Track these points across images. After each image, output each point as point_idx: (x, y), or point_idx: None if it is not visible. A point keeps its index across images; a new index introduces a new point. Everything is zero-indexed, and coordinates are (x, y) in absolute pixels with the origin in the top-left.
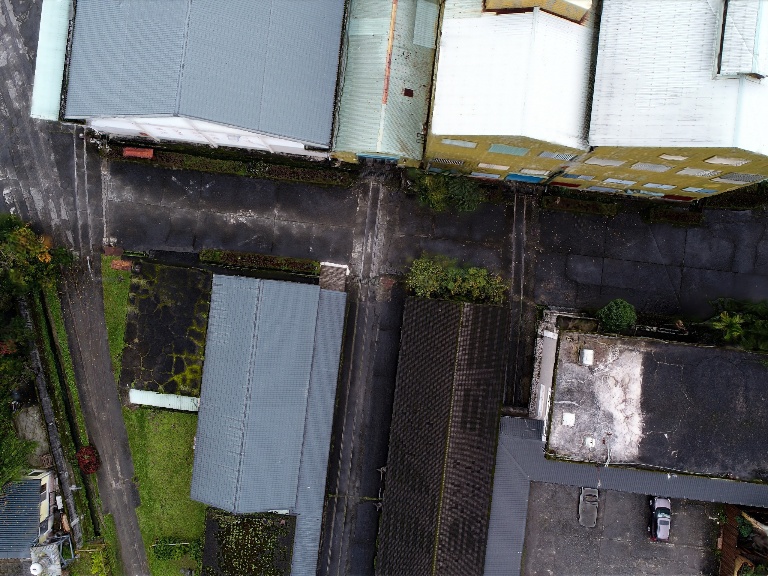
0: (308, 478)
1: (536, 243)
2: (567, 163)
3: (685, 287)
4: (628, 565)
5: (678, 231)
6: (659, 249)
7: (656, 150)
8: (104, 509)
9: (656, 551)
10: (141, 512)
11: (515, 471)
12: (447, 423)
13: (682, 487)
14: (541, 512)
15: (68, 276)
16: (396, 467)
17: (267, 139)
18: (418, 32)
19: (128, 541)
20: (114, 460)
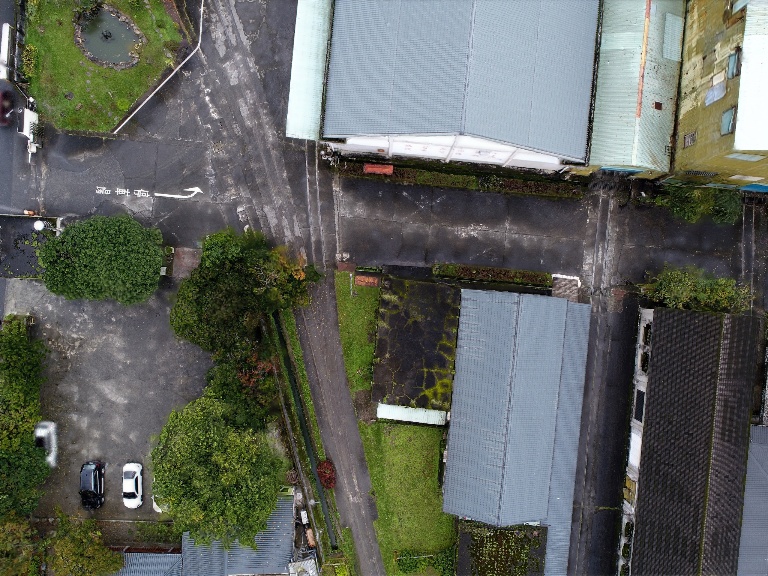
0: (557, 489)
1: (765, 252)
2: None
3: None
4: None
5: None
6: None
7: None
8: (342, 523)
9: None
10: (379, 525)
11: (762, 479)
12: (710, 433)
13: None
14: None
15: None
16: (651, 477)
17: (520, 154)
18: (667, 46)
19: (366, 554)
20: (351, 474)
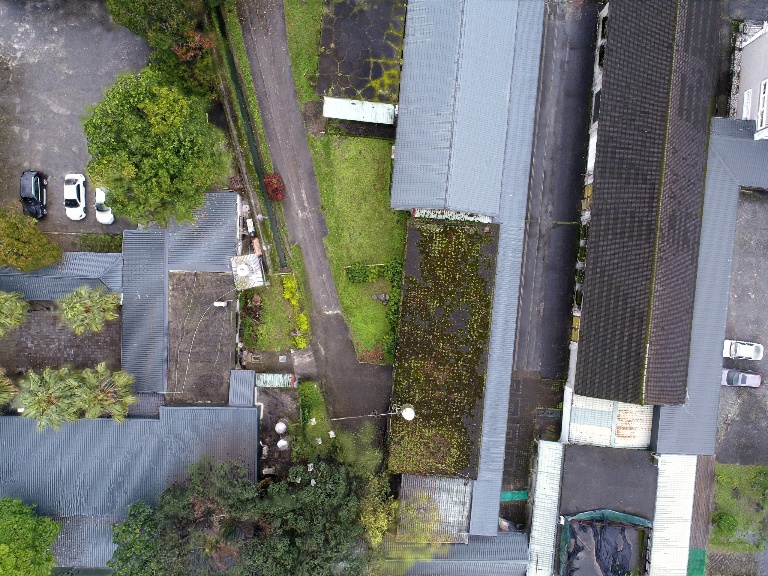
0: (510, 186)
1: None
2: None
3: None
4: None
5: None
6: None
7: None
8: (291, 239)
9: None
10: (329, 241)
11: (724, 174)
12: (666, 106)
13: None
14: (741, 234)
15: (249, 1)
16: (606, 165)
17: None
18: None
19: (316, 271)
20: (300, 189)
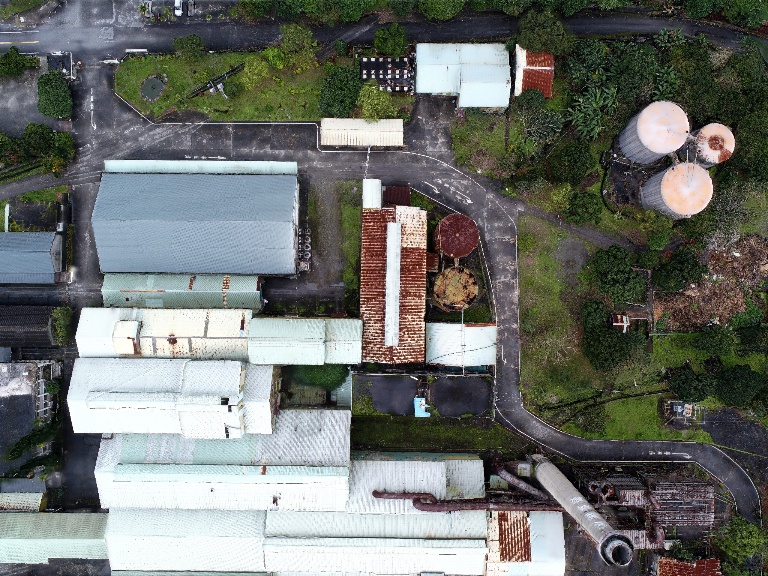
0: None
1: None
2: None
3: None
4: None
5: None
6: None
7: None
8: None
9: None
10: None
11: None
12: (1, 326)
13: None
14: None
15: None
16: None
17: None
18: (150, 301)
19: None
20: None
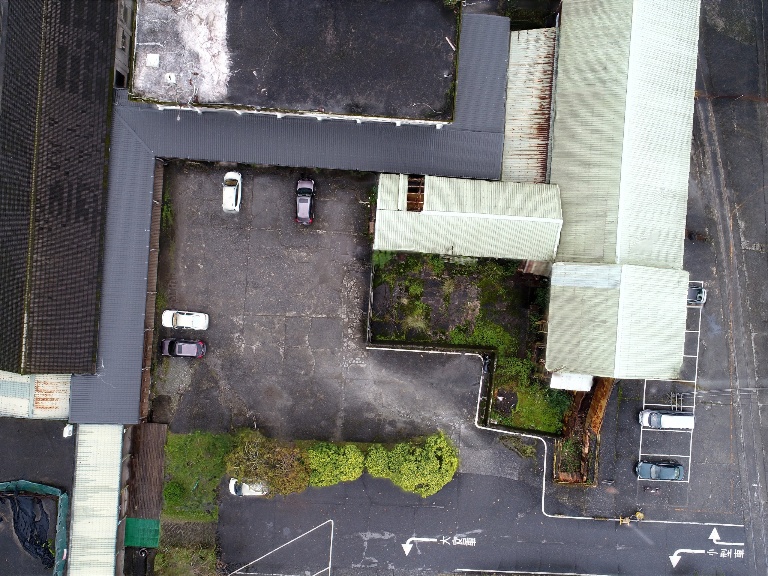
0: None
1: None
2: None
3: None
4: (279, 254)
5: None
6: None
7: None
8: None
9: (307, 239)
10: None
11: (137, 145)
12: (38, 78)
13: (309, 154)
14: (188, 205)
15: None
16: (5, 138)
17: None
18: None
19: None
20: None
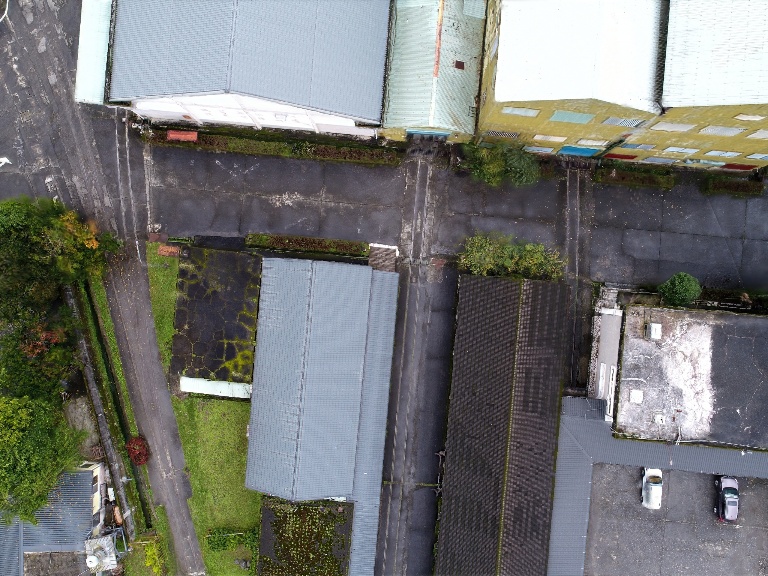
0: (364, 464)
1: (591, 218)
2: (631, 130)
3: (746, 260)
4: (694, 548)
5: (738, 202)
6: (718, 221)
7: (733, 110)
8: (155, 500)
9: (723, 533)
10: (193, 503)
11: (577, 452)
12: (509, 403)
13: (751, 466)
14: (602, 495)
15: (113, 264)
16: (456, 450)
17: (315, 117)
18: (468, 2)
19: (180, 533)
20: (164, 450)
